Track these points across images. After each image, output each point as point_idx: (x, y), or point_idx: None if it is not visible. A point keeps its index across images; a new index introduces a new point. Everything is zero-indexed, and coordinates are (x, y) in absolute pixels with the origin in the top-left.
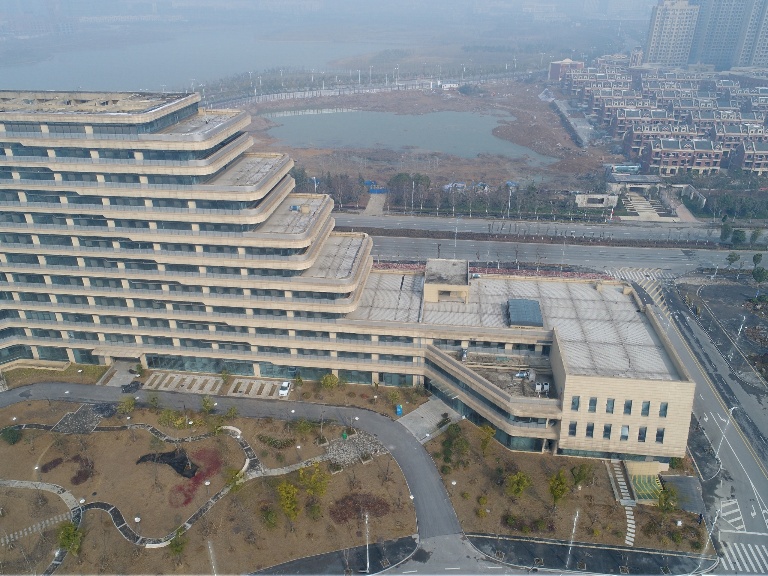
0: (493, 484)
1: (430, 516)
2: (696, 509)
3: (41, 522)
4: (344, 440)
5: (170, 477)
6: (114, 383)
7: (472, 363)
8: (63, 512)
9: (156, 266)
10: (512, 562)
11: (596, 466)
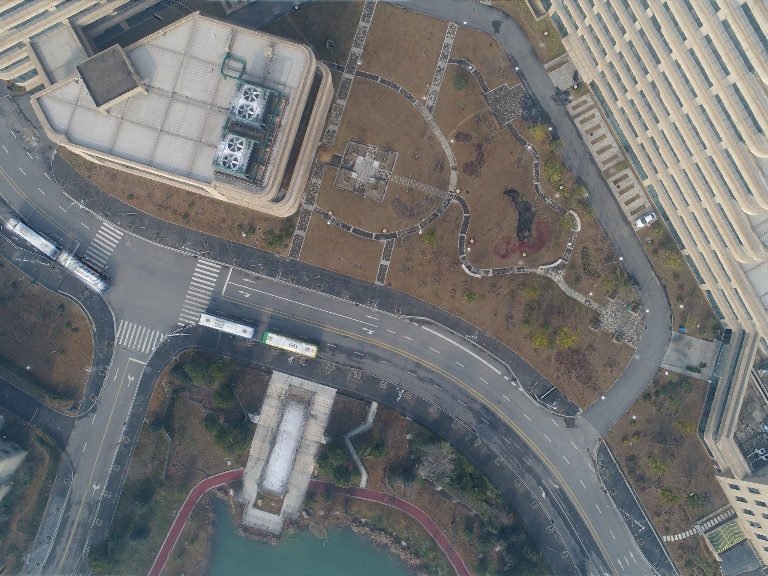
0: (656, 437)
1: (602, 410)
2: (726, 571)
3: (430, 186)
4: (625, 309)
5: (511, 227)
6: (555, 78)
7: (760, 381)
8: (444, 189)
9: (659, 62)
10: (602, 477)
11: (721, 499)
